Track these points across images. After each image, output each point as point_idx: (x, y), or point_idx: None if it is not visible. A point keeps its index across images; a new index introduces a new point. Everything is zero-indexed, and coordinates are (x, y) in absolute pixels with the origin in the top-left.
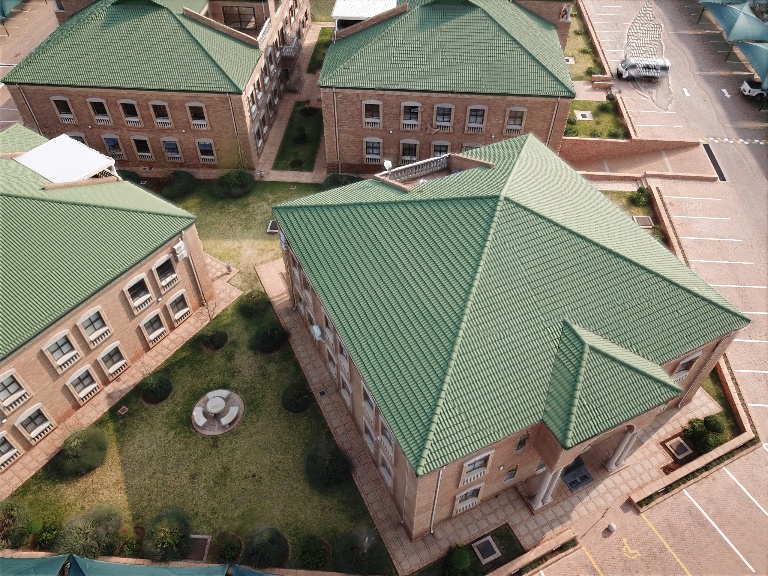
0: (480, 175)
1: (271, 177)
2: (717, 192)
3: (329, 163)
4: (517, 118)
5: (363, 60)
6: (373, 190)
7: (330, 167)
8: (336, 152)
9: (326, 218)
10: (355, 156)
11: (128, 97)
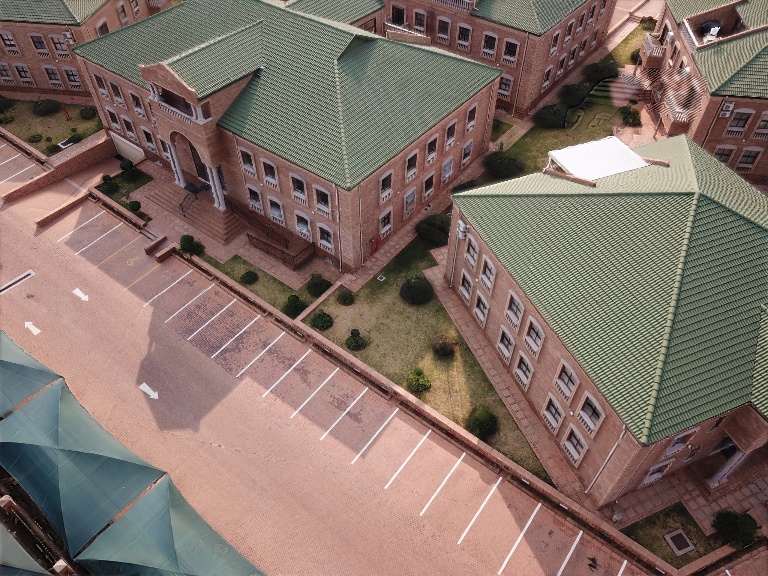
0: (761, 3)
1: (505, 145)
2: (661, 4)
3: (526, 108)
4: (603, 3)
5: (538, 3)
6: (736, 45)
7: (525, 112)
8: (531, 94)
9: (759, 69)
10: (537, 91)
11: (433, 133)
